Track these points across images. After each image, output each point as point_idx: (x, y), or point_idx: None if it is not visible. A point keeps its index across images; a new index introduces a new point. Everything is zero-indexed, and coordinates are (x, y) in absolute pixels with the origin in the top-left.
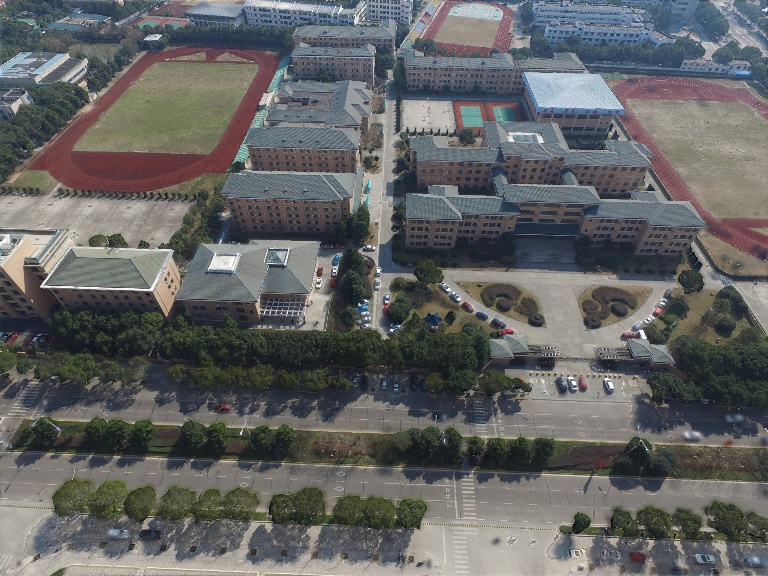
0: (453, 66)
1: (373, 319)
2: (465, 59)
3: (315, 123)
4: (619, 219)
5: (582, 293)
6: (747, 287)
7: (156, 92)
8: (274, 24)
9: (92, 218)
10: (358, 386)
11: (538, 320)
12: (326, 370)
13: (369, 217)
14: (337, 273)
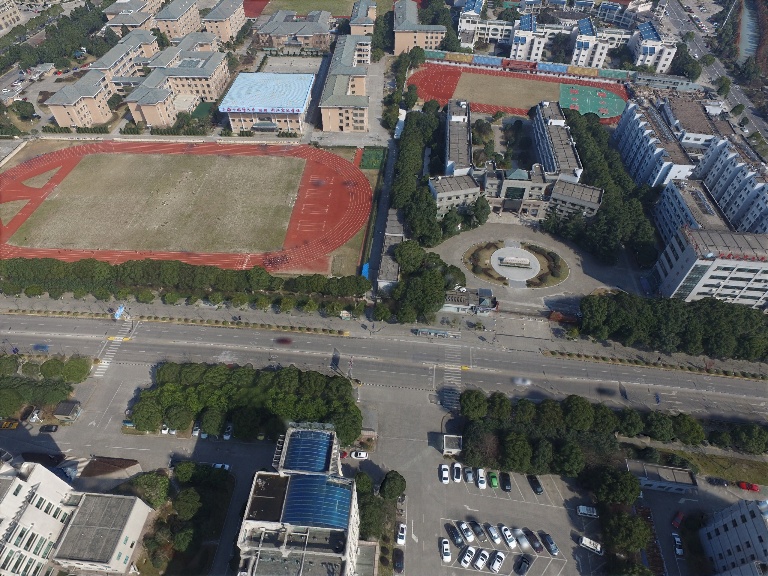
0: None
1: None
2: None
3: None
4: None
5: None
6: (15, 145)
7: None
8: None
9: (212, 1)
10: None
11: None
12: None
13: (165, 42)
14: None
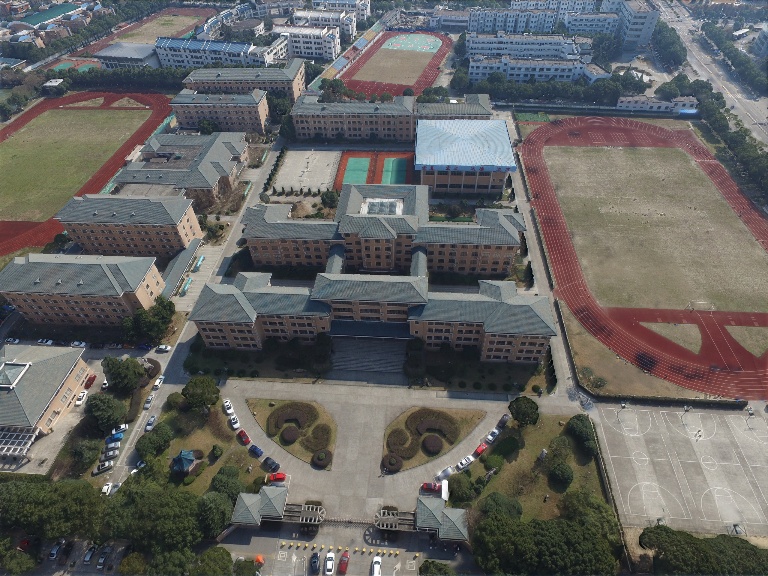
0: (343, 113)
1: (122, 453)
2: (357, 105)
3: (165, 185)
4: (449, 322)
5: (395, 418)
6: (610, 412)
7: (29, 145)
8: (187, 64)
9: None
10: (56, 558)
11: (321, 461)
12: (6, 542)
13: (174, 308)
14: (108, 384)
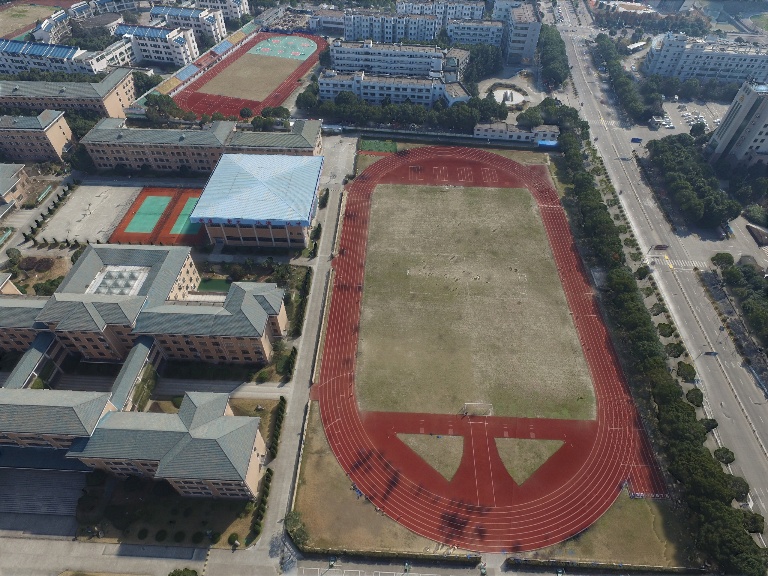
0: (142, 142)
1: None
2: (160, 133)
3: None
4: (119, 459)
5: None
6: (312, 575)
7: None
8: (9, 69)
9: None
10: None
11: None
12: None
13: None
14: None
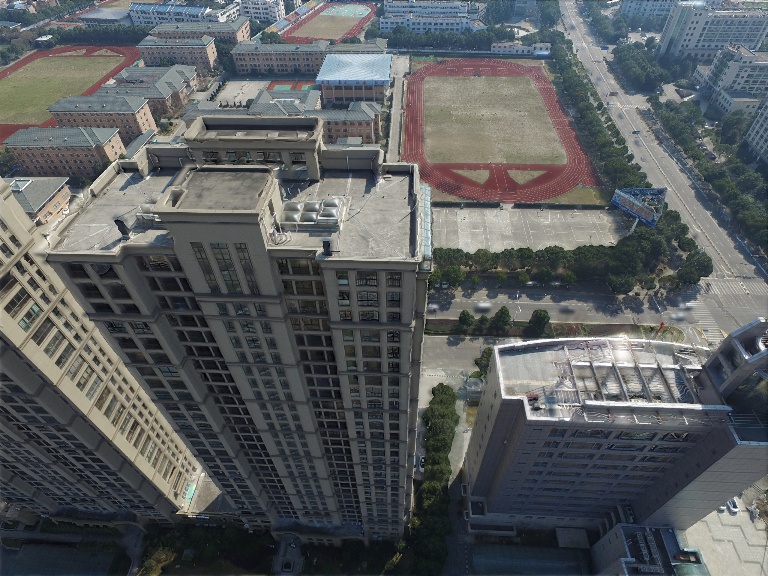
0: (271, 51)
1: None
2: (282, 45)
3: None
4: None
5: None
6: None
7: (26, 80)
8: None
9: None
10: None
11: None
12: None
13: None
14: None
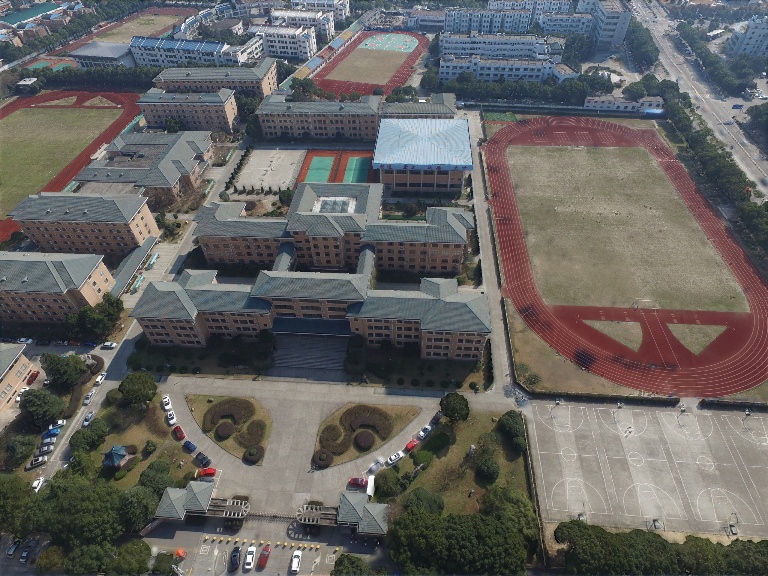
0: (308, 112)
1: (57, 448)
2: (322, 104)
3: (125, 183)
4: (387, 319)
5: (330, 414)
6: (544, 409)
7: None
8: (161, 63)
9: None
10: None
11: (252, 456)
12: None
13: (122, 305)
14: None
